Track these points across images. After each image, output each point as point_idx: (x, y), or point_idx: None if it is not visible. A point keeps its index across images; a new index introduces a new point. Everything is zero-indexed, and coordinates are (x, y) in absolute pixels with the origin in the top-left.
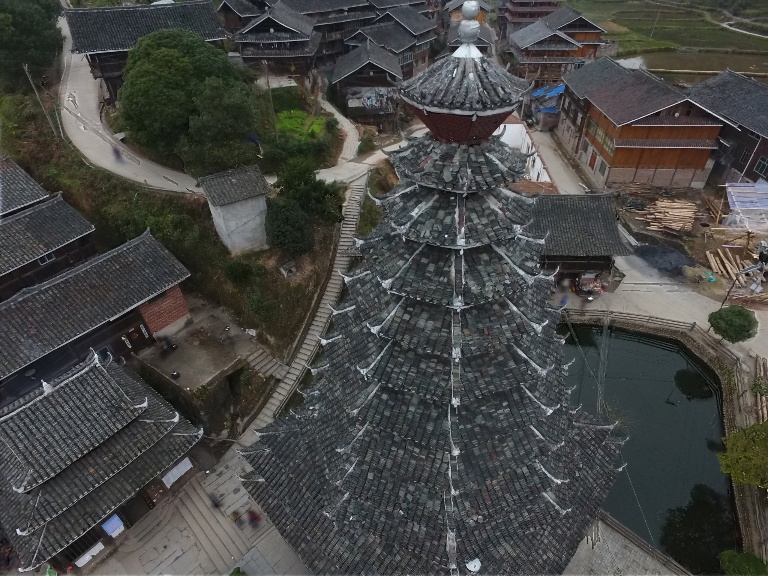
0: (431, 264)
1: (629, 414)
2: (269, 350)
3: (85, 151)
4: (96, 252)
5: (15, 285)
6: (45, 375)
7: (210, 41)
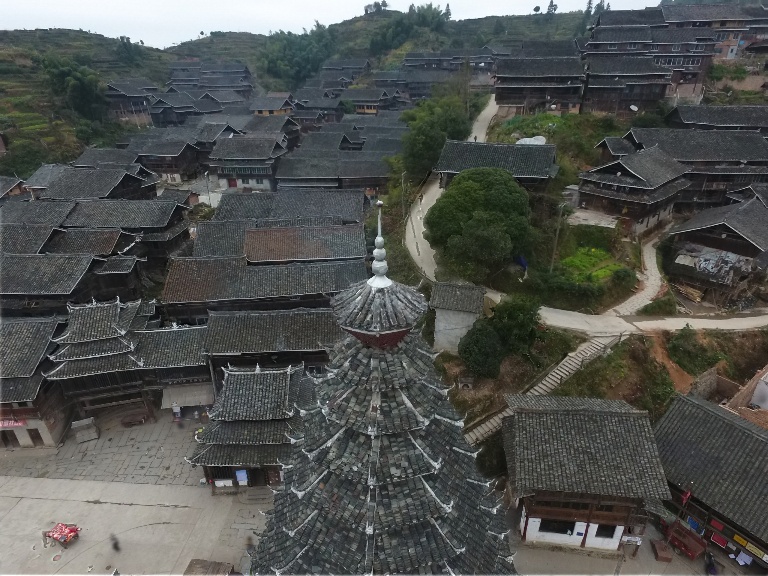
0: None
1: None
2: None
3: (408, 234)
4: None
5: (310, 303)
6: (282, 363)
7: (533, 177)
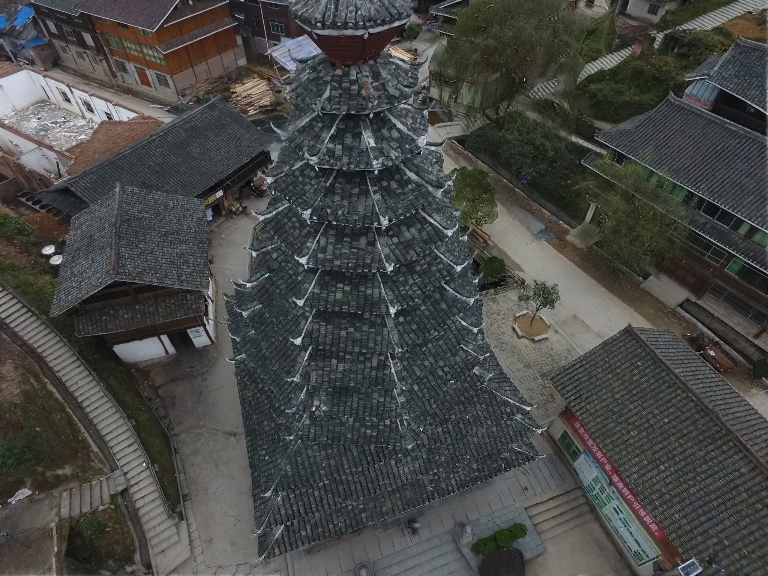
0: (392, 182)
1: None
2: (73, 483)
3: None
4: None
5: None
6: None
7: None
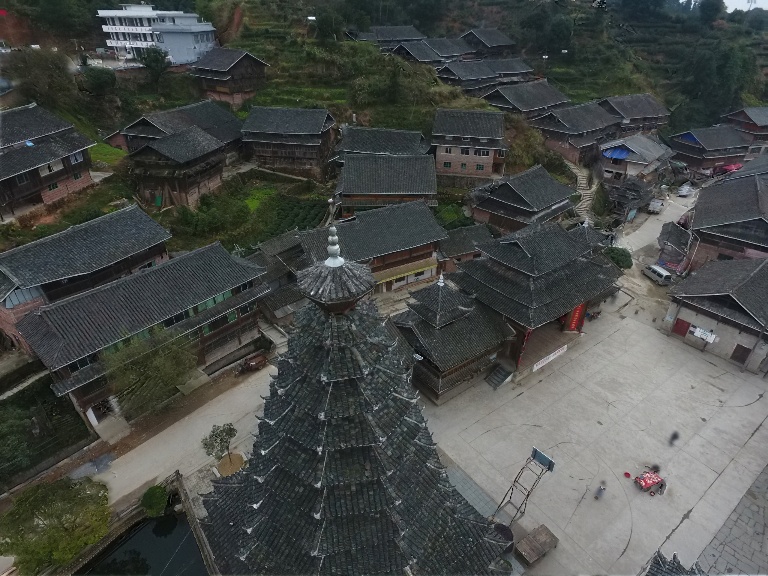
0: None
1: None
2: None
3: None
4: None
5: None
6: None
7: None
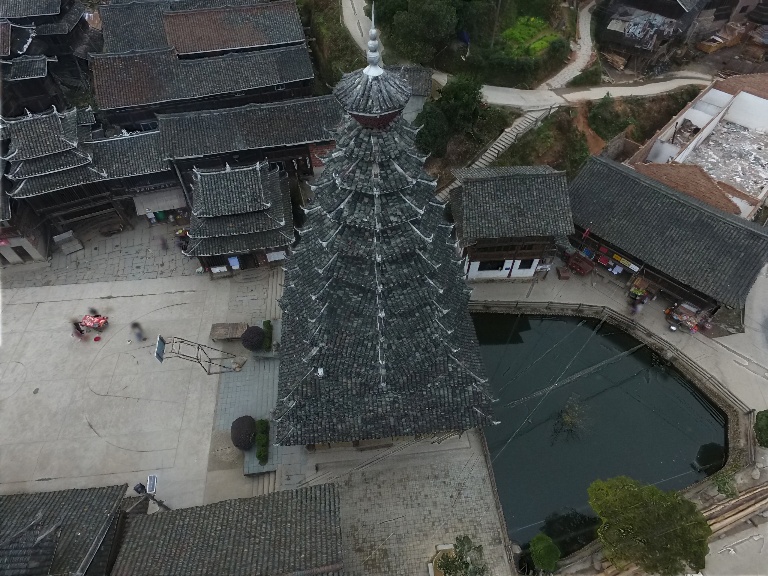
0: None
1: (588, 421)
2: None
3: (345, 10)
4: (311, 94)
5: (257, 98)
6: (244, 162)
7: None
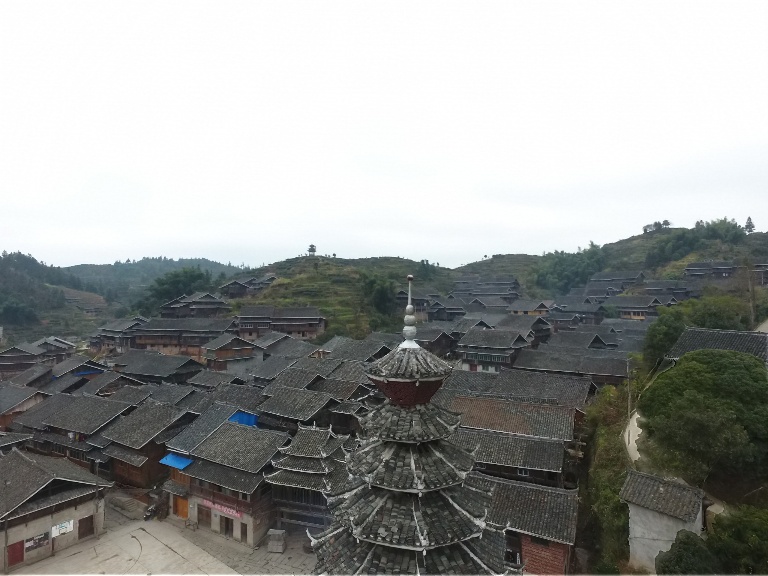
0: None
1: None
2: None
3: (630, 427)
4: None
5: (495, 475)
6: None
7: None
